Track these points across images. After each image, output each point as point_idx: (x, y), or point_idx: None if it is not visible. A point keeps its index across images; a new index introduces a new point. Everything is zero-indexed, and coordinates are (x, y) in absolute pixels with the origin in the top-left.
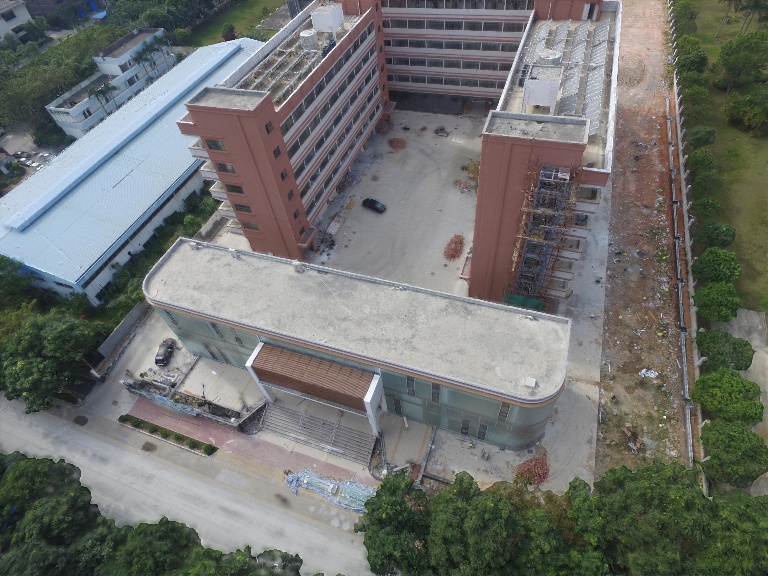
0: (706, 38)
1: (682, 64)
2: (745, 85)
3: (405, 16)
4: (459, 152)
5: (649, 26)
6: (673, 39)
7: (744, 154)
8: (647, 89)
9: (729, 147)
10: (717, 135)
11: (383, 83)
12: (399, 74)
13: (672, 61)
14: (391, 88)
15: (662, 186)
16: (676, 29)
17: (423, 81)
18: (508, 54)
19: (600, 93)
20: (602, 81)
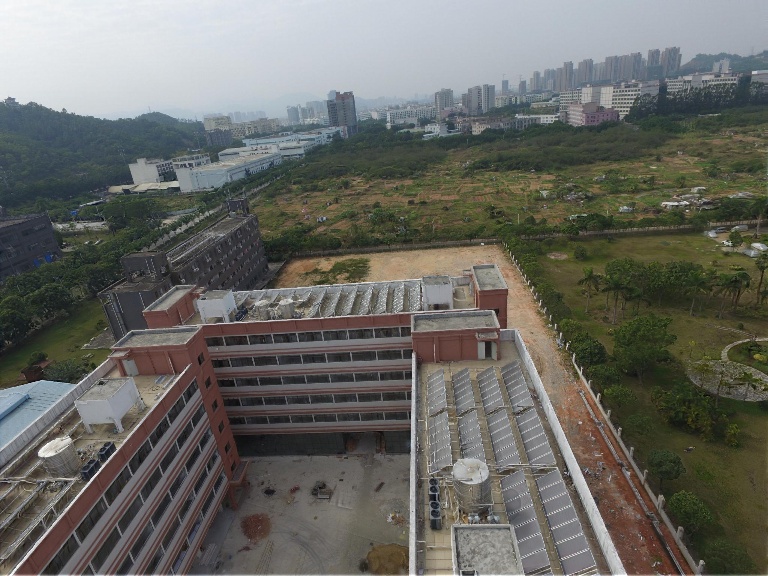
0: (579, 314)
1: (581, 356)
2: (650, 367)
3: (249, 353)
4: (351, 529)
5: (520, 306)
6: (550, 320)
7: (717, 472)
8: (553, 382)
9: (693, 463)
10: (667, 444)
11: (225, 444)
12: (252, 416)
13: (562, 345)
14: (244, 432)
15: (655, 553)
16: (548, 309)
17: (286, 421)
18: (390, 383)
19: (591, 560)
20: (576, 518)
